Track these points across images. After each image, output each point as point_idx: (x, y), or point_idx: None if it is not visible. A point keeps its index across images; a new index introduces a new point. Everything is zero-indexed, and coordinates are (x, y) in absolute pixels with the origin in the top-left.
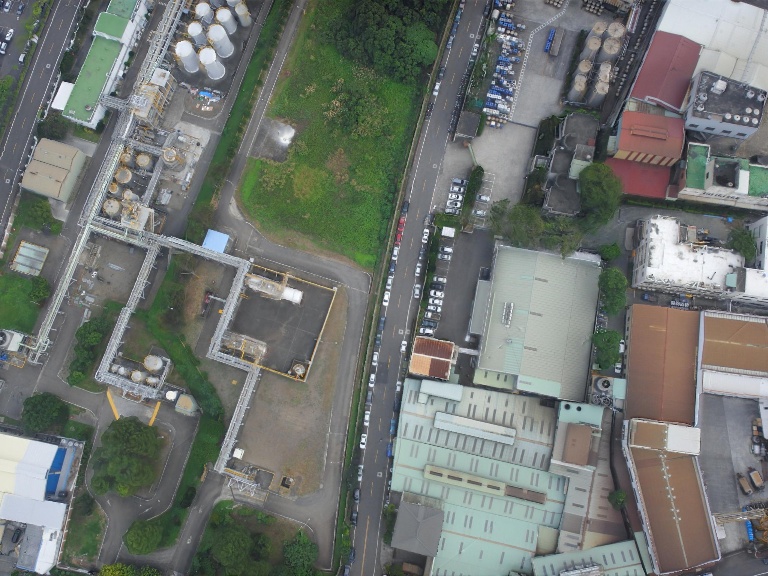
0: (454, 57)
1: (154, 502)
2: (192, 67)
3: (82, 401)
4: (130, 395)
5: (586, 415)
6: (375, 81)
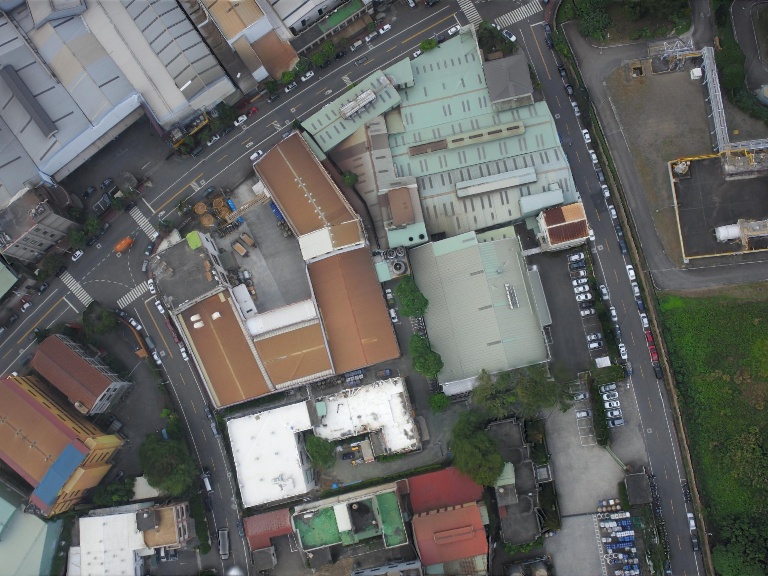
0: (691, 569)
1: (748, 5)
2: None
3: None
4: None
5: (403, 236)
6: (765, 505)
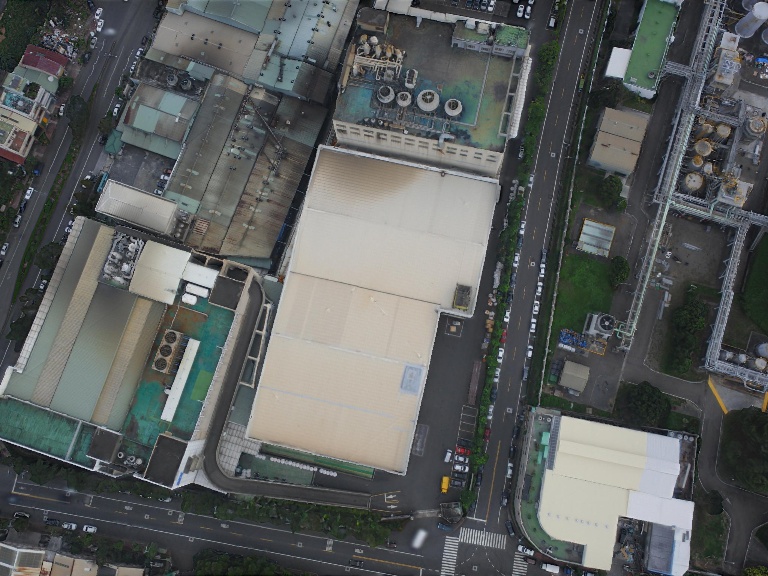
0: None
1: None
2: (752, 31)
3: (679, 391)
4: (734, 384)
5: None
6: None
